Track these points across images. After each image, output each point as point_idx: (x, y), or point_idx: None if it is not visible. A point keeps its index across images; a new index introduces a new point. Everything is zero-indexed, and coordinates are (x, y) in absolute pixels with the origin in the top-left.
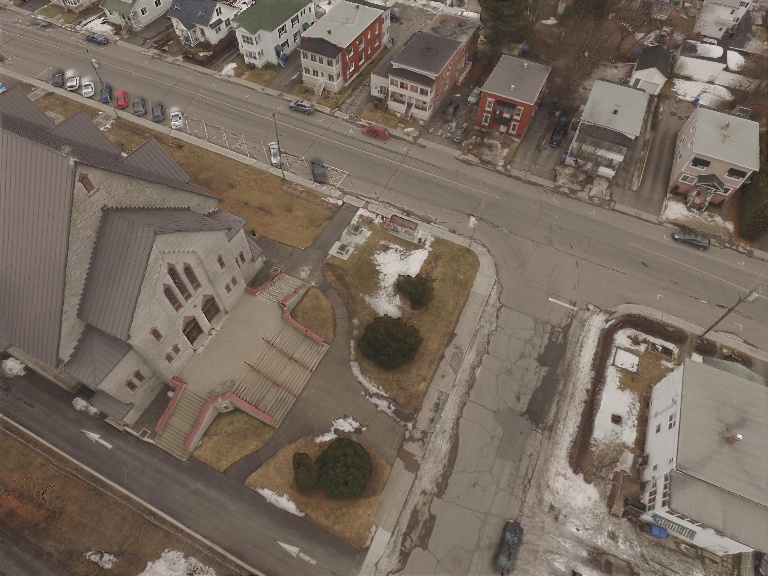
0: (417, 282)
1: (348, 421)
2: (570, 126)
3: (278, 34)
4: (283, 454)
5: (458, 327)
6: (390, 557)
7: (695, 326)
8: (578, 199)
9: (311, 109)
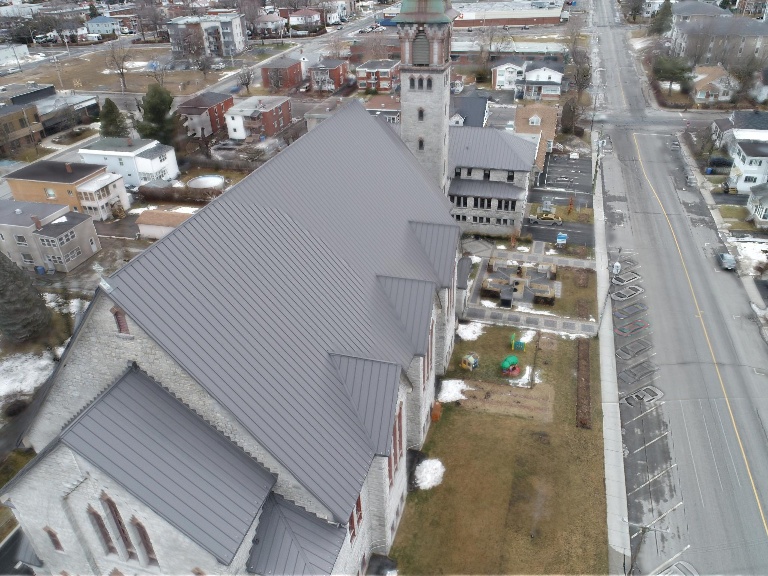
0: None
1: None
2: None
3: None
4: None
5: None
6: None
7: None
8: None
9: None
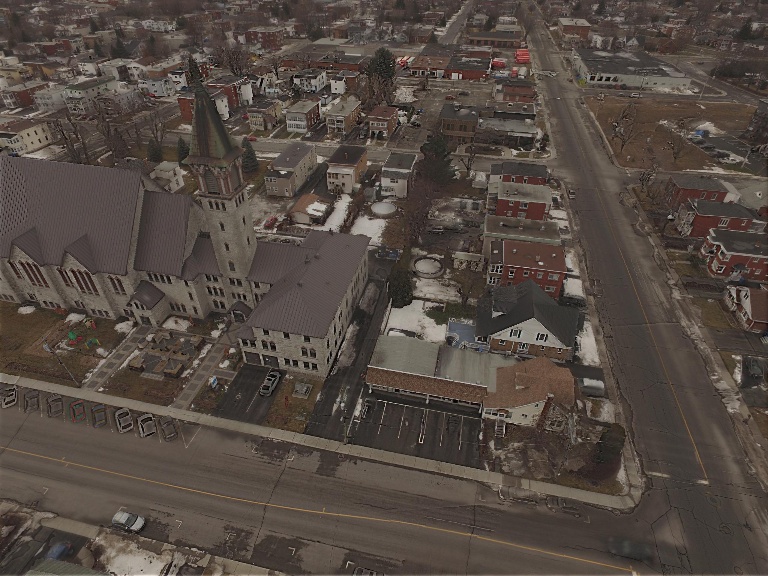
0: None
1: None
2: None
3: None
4: None
5: None
6: None
7: None
8: None
9: None
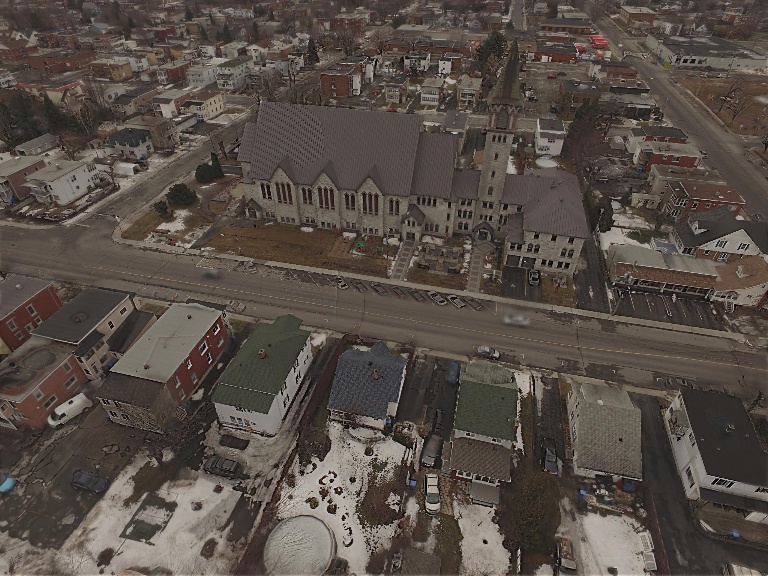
0: None
1: (205, 187)
2: None
3: None
4: (229, 179)
5: None
6: (194, 172)
7: (15, 225)
8: (20, 274)
9: None
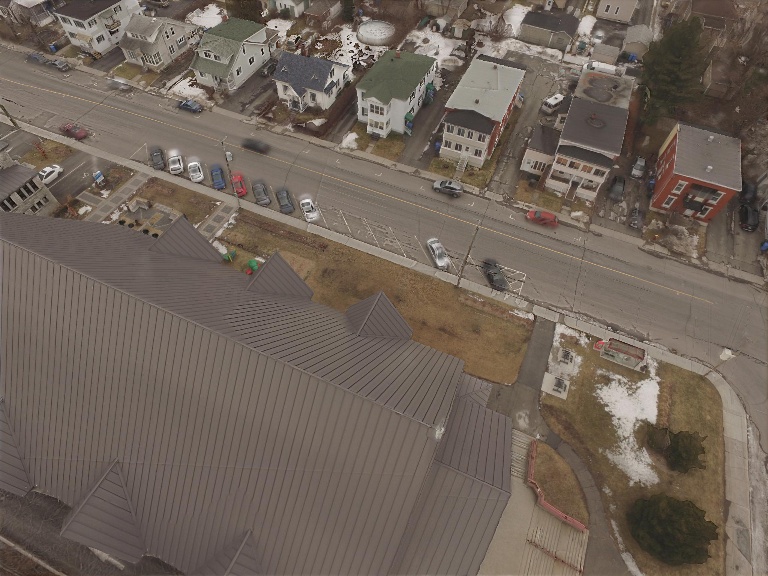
0: (688, 444)
1: None
2: (761, 205)
3: (409, 101)
4: None
5: (728, 491)
6: None
7: None
8: None
9: (461, 192)
